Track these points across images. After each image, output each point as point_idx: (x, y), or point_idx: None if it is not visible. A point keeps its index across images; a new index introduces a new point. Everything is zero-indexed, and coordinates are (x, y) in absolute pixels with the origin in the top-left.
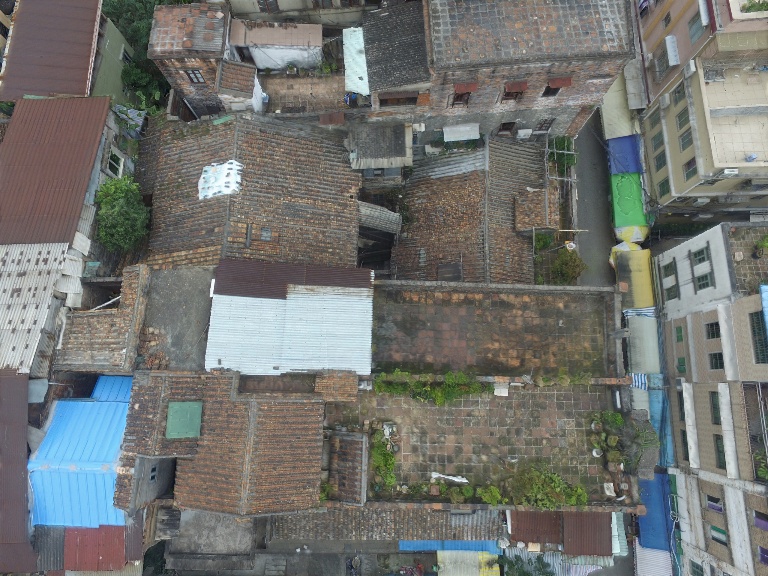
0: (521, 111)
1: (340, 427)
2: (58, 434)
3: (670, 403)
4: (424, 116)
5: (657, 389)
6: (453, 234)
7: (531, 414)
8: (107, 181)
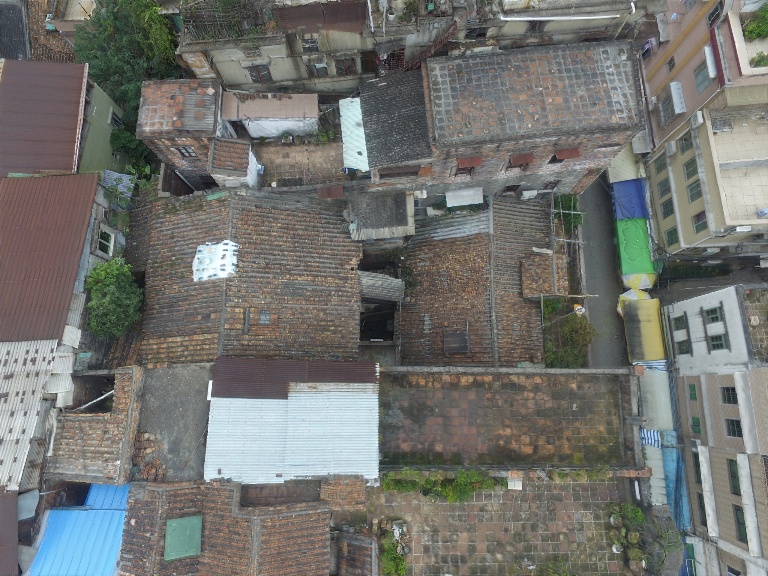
0: (526, 176)
1: (347, 527)
2: (51, 550)
3: (685, 463)
4: (426, 184)
5: (671, 447)
6: (458, 301)
7: (547, 507)
8: (97, 266)
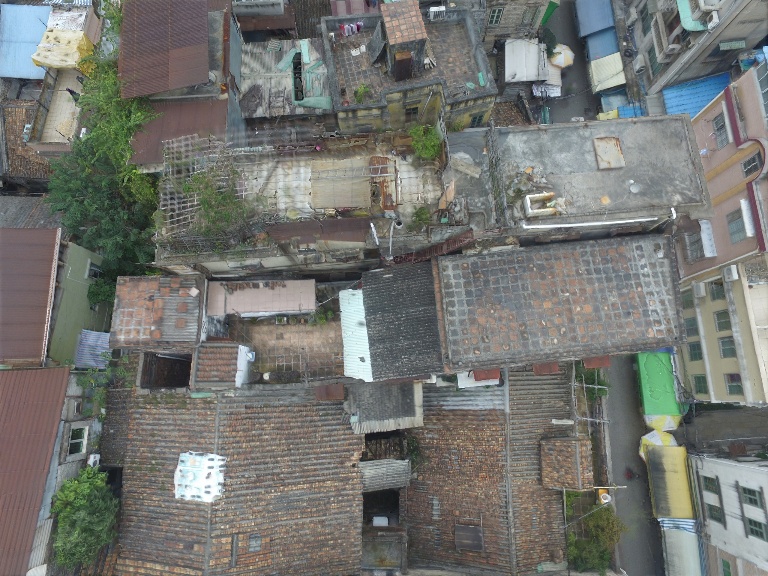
0: None
1: None
2: None
3: None
4: None
5: None
6: (471, 487)
7: None
8: (66, 484)
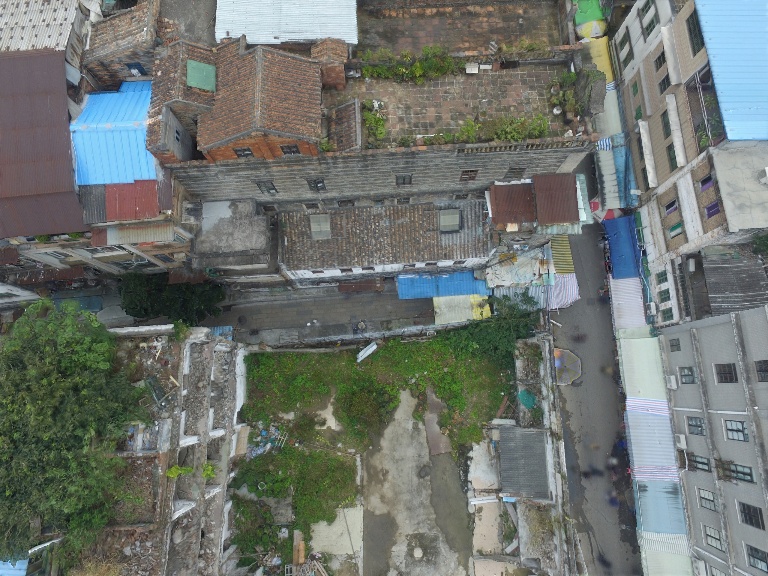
0: None
1: None
2: (93, 110)
3: (632, 153)
4: None
5: (620, 146)
6: None
7: (499, 89)
8: None
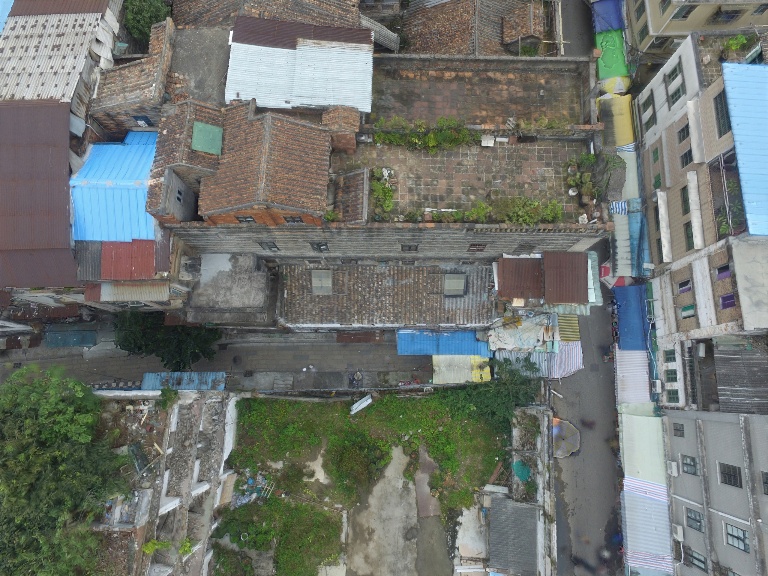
0: None
1: None
2: (95, 164)
3: (647, 221)
4: None
5: (636, 212)
6: (446, 50)
7: (514, 164)
8: None
